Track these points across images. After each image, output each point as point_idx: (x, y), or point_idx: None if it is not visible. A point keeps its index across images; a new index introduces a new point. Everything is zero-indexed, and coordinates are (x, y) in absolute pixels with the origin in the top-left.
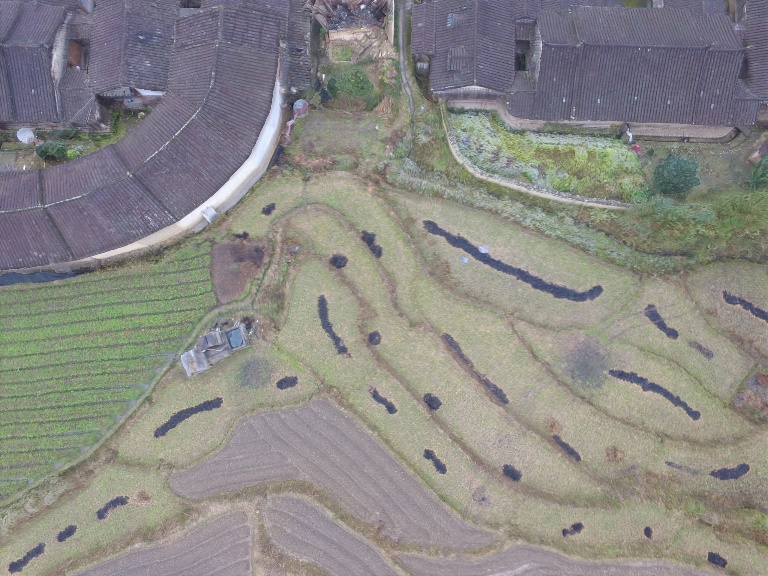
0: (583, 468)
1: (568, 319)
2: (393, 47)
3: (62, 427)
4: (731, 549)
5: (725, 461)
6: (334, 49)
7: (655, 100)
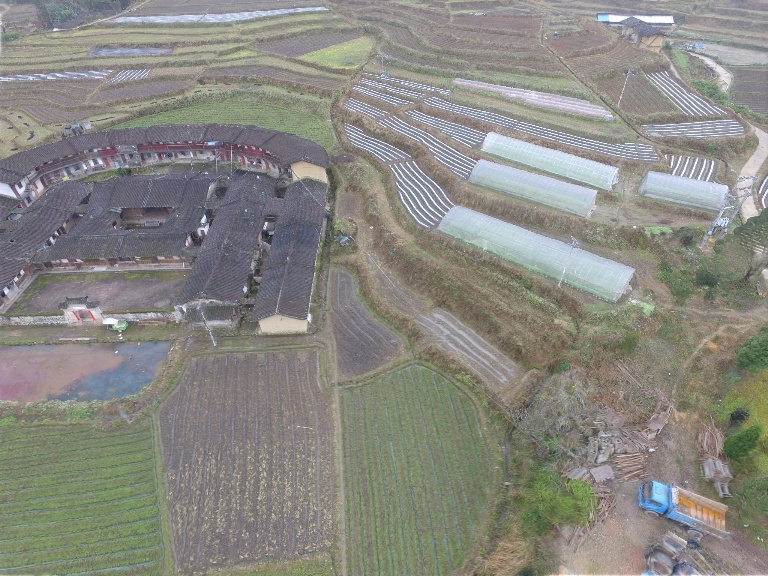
0: None
1: None
2: None
3: (152, 120)
4: None
5: None
6: None
7: None
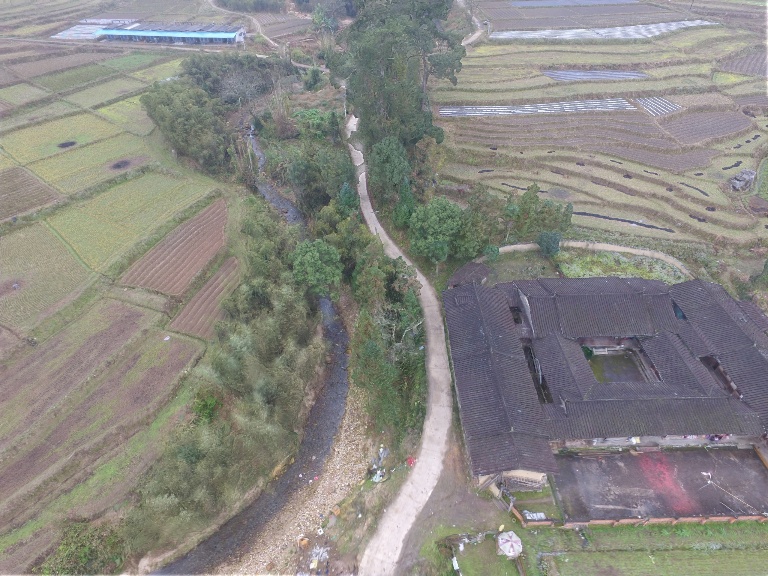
0: (550, 168)
1: None
2: None
3: None
4: None
5: None
6: None
7: None
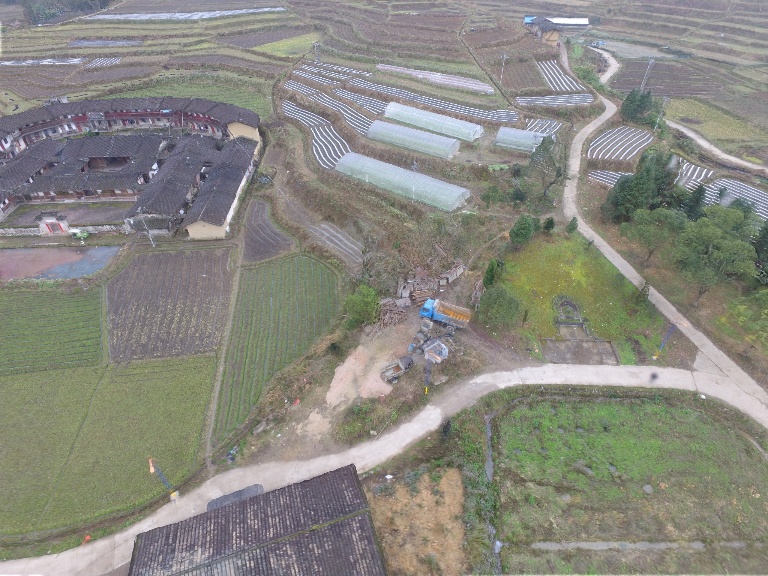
0: None
1: None
2: None
3: None
4: None
5: None
6: None
7: None
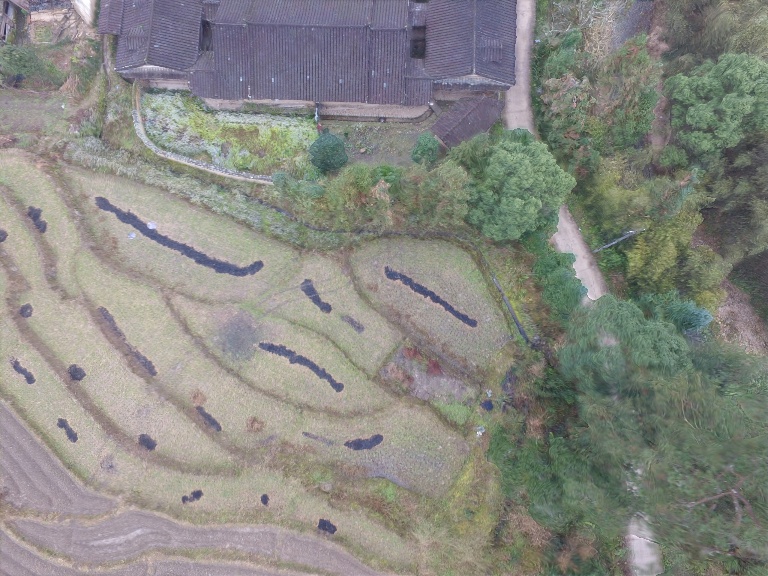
0: (220, 438)
1: (227, 293)
2: (93, 28)
3: None
4: (342, 516)
5: (360, 432)
6: (37, 30)
7: (327, 79)
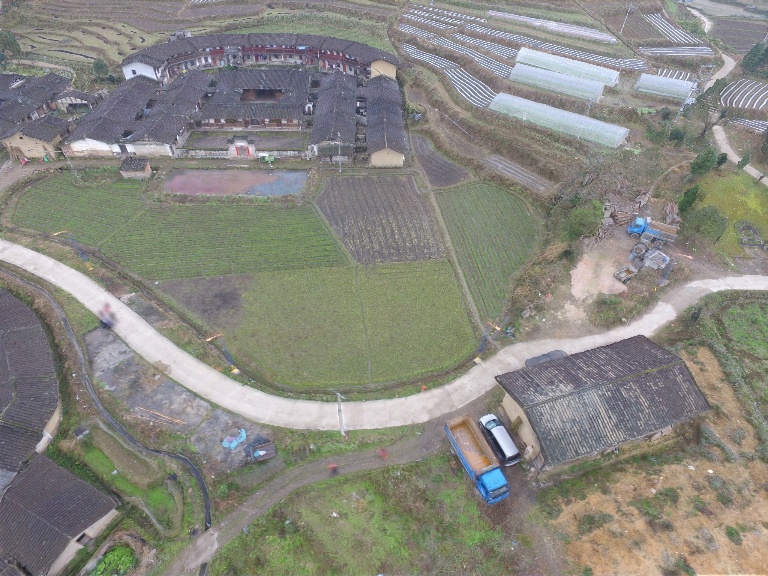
0: None
1: None
2: None
3: None
4: None
5: None
6: None
7: None
